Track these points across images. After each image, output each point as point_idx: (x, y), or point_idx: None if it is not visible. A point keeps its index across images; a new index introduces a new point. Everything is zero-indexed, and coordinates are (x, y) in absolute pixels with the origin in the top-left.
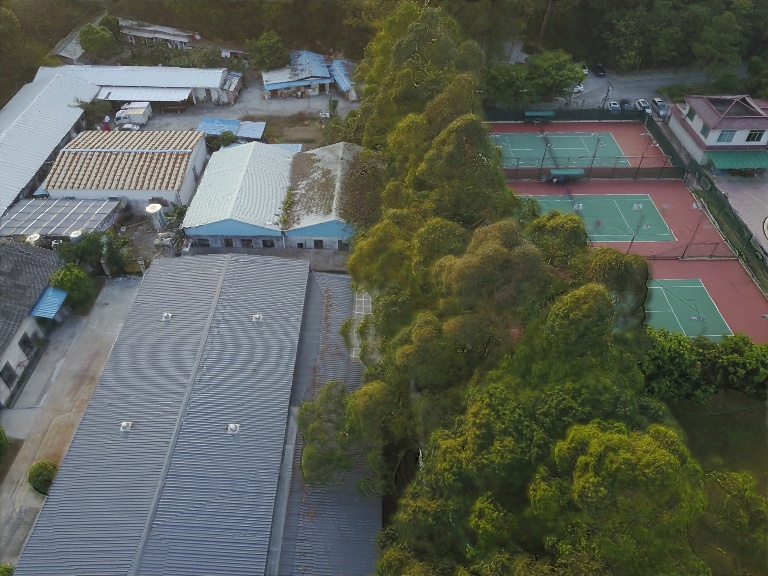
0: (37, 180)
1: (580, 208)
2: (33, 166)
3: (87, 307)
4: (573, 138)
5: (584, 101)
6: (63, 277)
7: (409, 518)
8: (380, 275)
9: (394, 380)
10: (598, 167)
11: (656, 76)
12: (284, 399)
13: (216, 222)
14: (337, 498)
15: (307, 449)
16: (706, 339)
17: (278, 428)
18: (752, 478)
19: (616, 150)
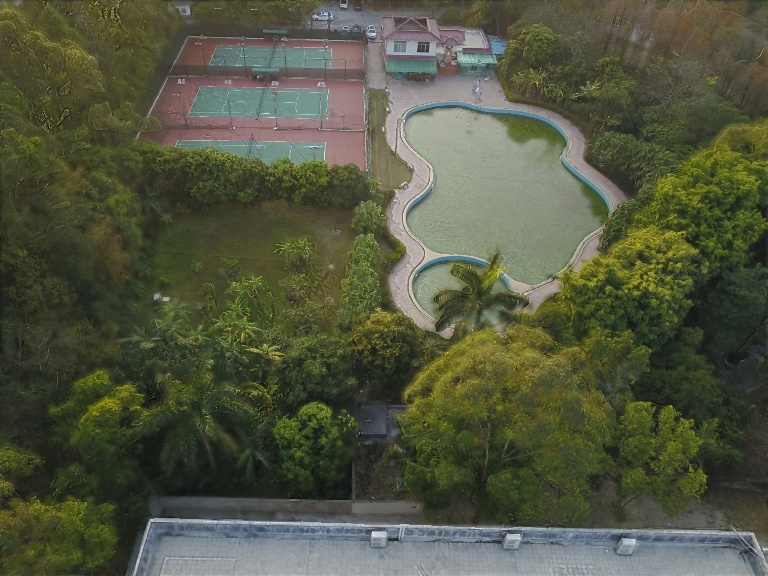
0: None
1: (229, 83)
2: None
3: None
4: (298, 51)
5: (312, 22)
6: None
7: None
8: None
9: None
10: (291, 67)
11: (407, 12)
12: None
13: None
14: None
15: None
16: (257, 159)
17: None
18: (38, 139)
19: None
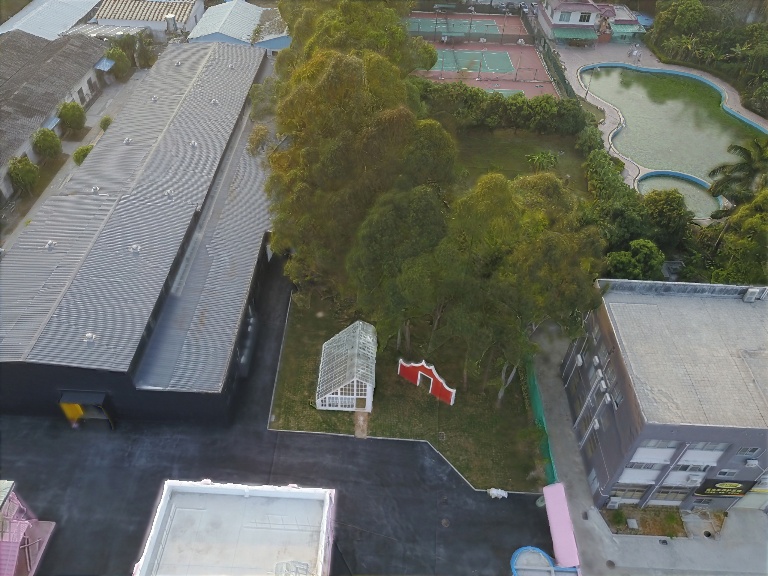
0: (88, 19)
1: (446, 39)
2: (86, 9)
3: (125, 80)
4: None
5: None
6: (113, 51)
7: None
8: (293, 3)
9: (295, 46)
10: (474, 32)
11: None
12: (244, 95)
13: (209, 34)
14: None
15: None
16: (498, 93)
17: (239, 104)
18: None
19: (495, 29)
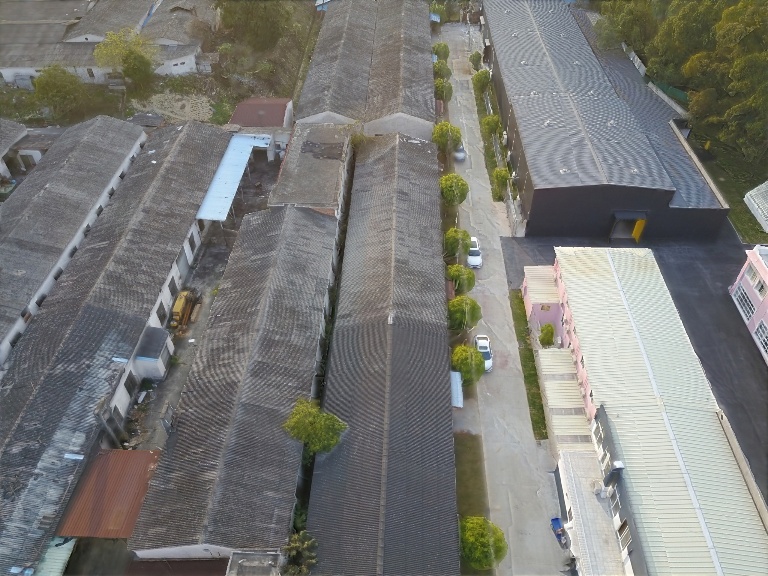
0: None
1: None
2: None
3: (438, 32)
4: None
5: None
6: (438, 7)
7: (675, 6)
8: None
9: None
10: None
11: None
12: (579, 31)
13: None
14: (613, 60)
15: (603, 33)
16: None
17: (582, 37)
18: None
19: None
